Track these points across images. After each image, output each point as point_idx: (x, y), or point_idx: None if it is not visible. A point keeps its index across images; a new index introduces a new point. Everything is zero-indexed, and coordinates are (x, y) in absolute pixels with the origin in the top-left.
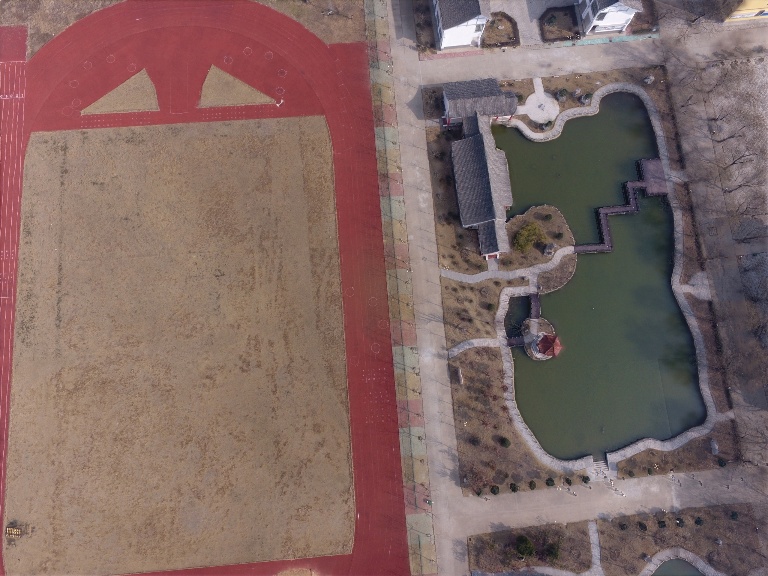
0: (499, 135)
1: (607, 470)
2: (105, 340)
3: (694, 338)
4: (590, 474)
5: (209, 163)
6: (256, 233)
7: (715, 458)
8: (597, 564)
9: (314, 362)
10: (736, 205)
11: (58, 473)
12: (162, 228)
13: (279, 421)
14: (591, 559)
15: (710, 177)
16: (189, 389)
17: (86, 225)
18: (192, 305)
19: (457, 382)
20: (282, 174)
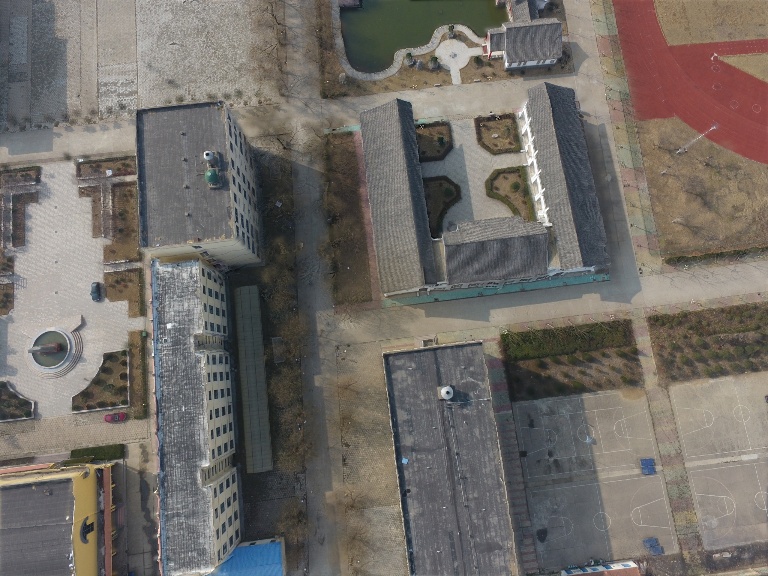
0: (498, 24)
1: None
2: None
3: None
4: None
5: None
6: None
7: None
8: None
9: None
10: None
11: None
12: None
13: None
14: None
15: None
16: None
17: None
18: None
19: None
20: None
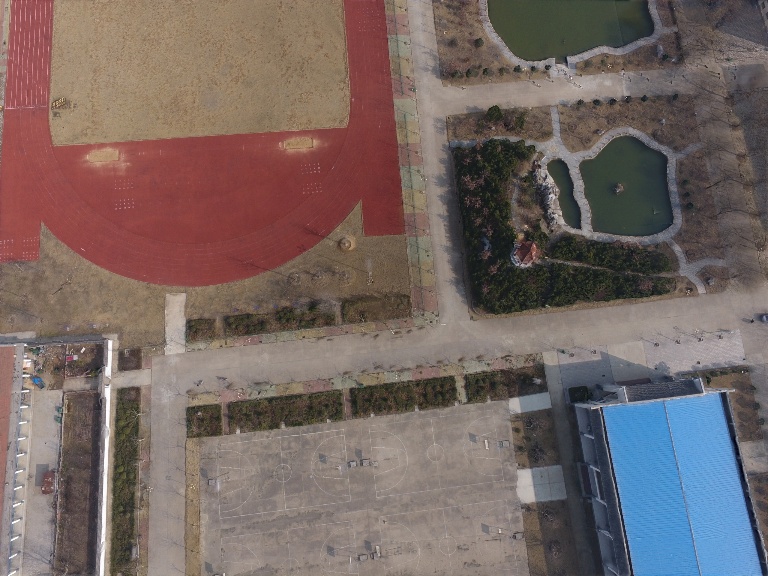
0: None
1: (567, 69)
2: None
3: None
4: (552, 71)
5: None
6: None
7: (660, 60)
8: (557, 136)
9: None
10: None
11: (95, 64)
12: None
13: (284, 29)
14: (552, 131)
15: None
16: (207, 4)
17: None
18: None
19: (438, 1)
20: None
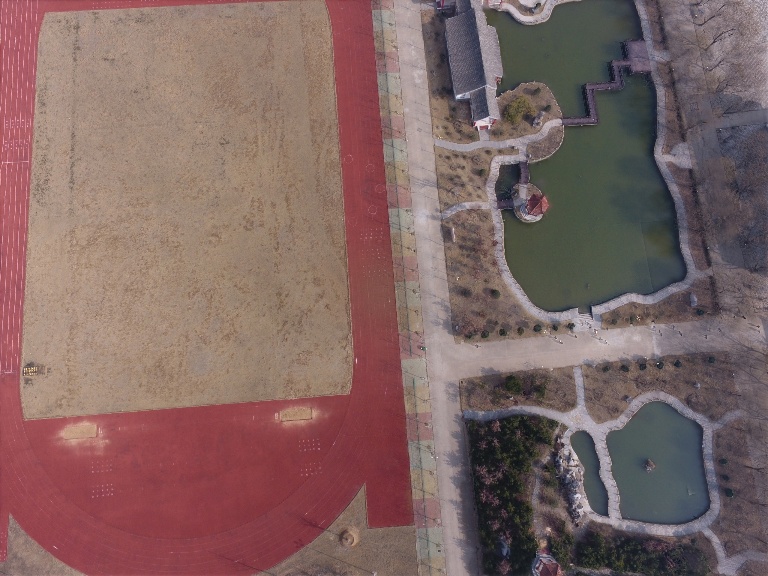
0: (491, 17)
1: (592, 321)
2: (116, 201)
3: (675, 203)
4: (576, 324)
5: (214, 42)
6: (259, 105)
7: (694, 310)
8: (582, 404)
9: (314, 222)
10: (716, 83)
11: (72, 320)
12: (170, 100)
13: (281, 275)
14: (576, 399)
15: (692, 57)
16: (196, 245)
17: (98, 97)
18: (198, 170)
19: (450, 241)
20: (284, 52)
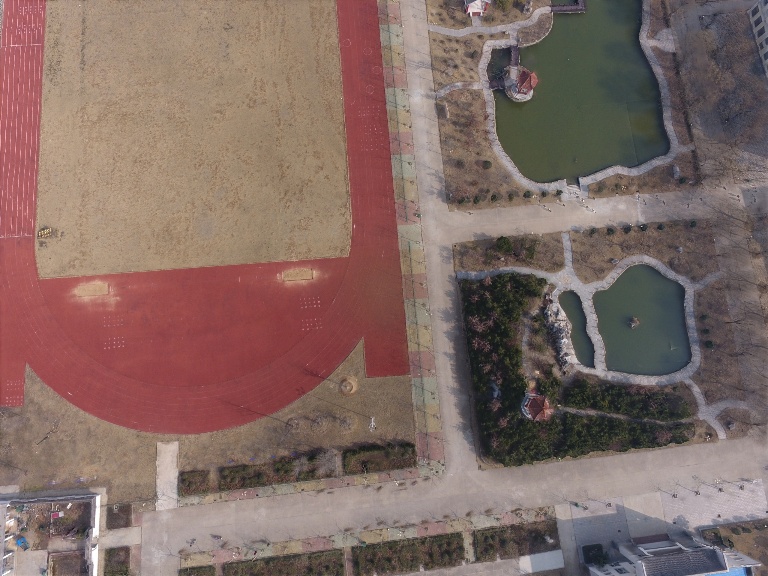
0: None
1: (579, 191)
2: (125, 80)
3: (659, 83)
4: (564, 194)
5: None
6: None
7: (677, 181)
8: (569, 266)
9: (314, 100)
10: None
11: (84, 188)
12: None
13: (283, 148)
14: (564, 261)
15: None
16: (201, 121)
17: None
18: (203, 52)
19: (444, 118)
20: None
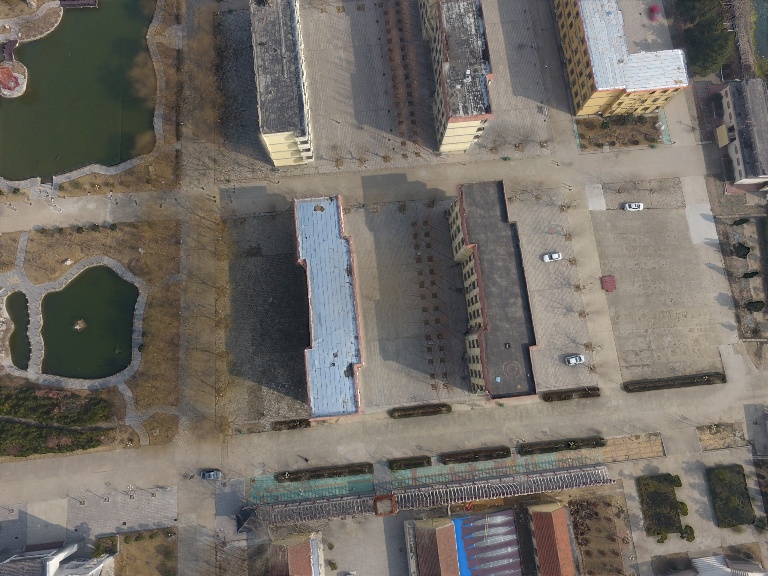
0: None
1: (50, 190)
2: None
3: (157, 81)
4: (33, 192)
5: None
6: None
7: None
8: (20, 266)
9: None
10: None
11: None
12: None
13: None
14: (14, 261)
15: None
16: None
17: None
18: None
19: None
20: None
